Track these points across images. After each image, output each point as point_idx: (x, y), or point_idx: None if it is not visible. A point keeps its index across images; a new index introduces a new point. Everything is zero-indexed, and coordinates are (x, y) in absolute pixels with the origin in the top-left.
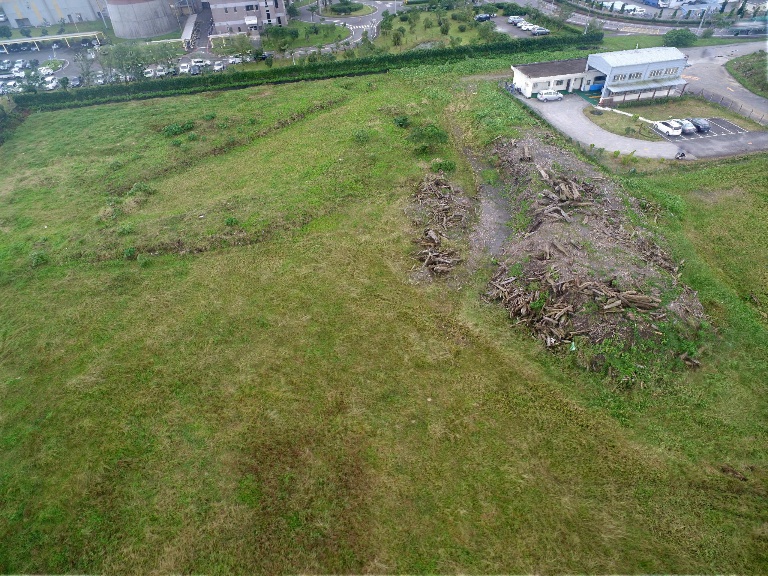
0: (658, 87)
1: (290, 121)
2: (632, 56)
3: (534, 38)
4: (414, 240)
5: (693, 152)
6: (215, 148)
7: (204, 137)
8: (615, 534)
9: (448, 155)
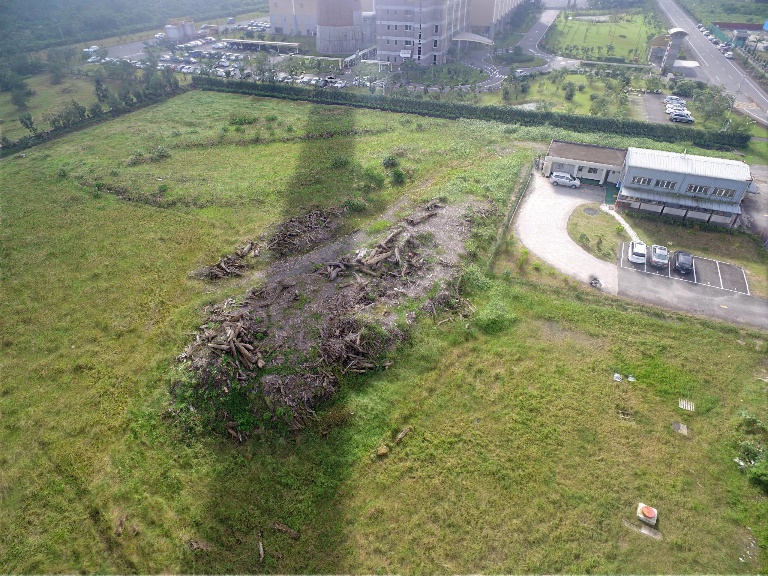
0: (691, 206)
1: (316, 136)
2: (671, 160)
3: (645, 121)
4: (236, 246)
5: (624, 286)
6: (241, 140)
7: (243, 130)
8: (1, 491)
9: (380, 199)
